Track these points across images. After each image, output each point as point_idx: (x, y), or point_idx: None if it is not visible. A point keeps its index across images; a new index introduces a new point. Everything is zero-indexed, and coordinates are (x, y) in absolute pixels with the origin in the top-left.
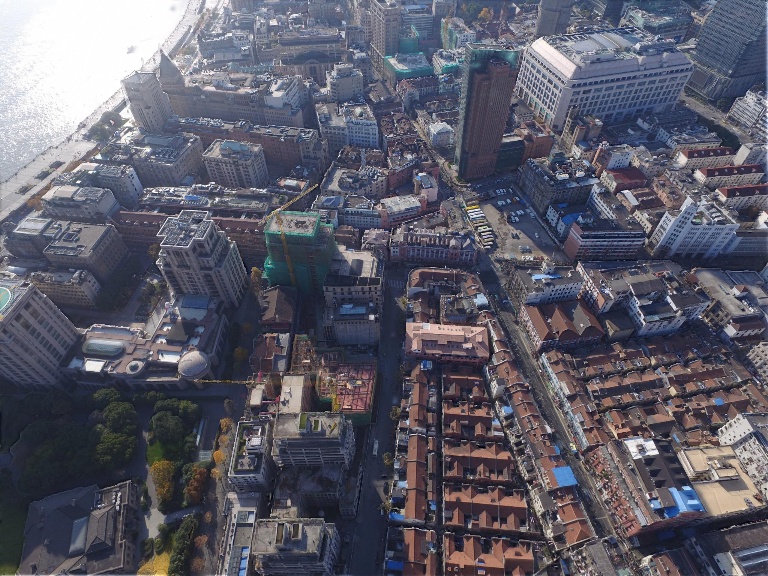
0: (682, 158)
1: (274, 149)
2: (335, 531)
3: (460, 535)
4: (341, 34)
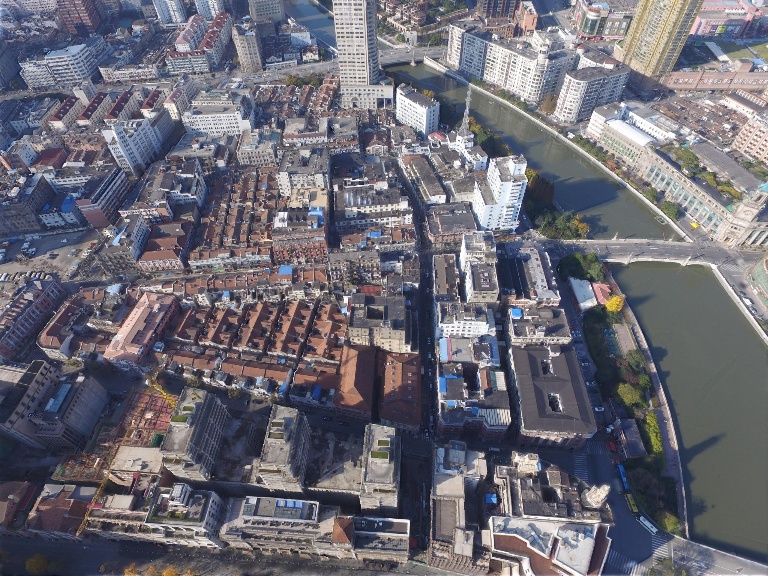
0: (57, 124)
1: None
2: None
3: (306, 349)
4: None
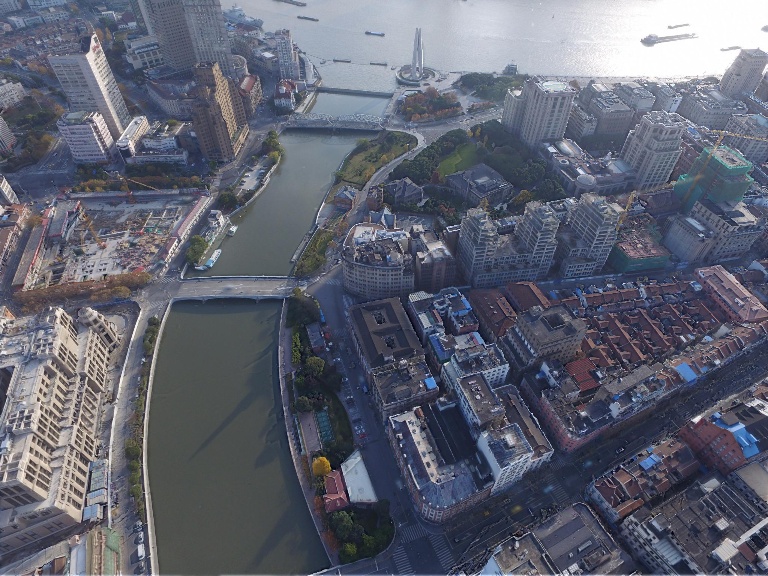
0: None
1: None
2: (553, 253)
3: None
4: None
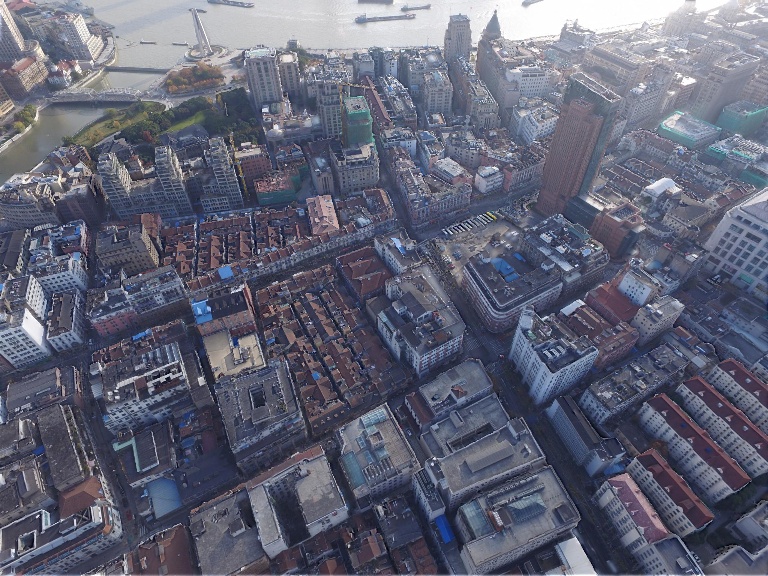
0: None
1: None
2: (183, 190)
3: None
4: (685, 79)
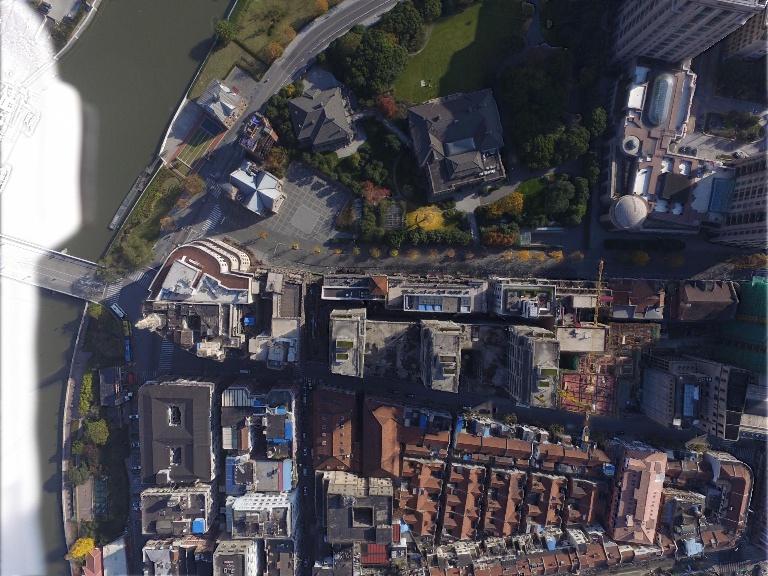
0: None
1: None
2: None
3: (443, 475)
4: None
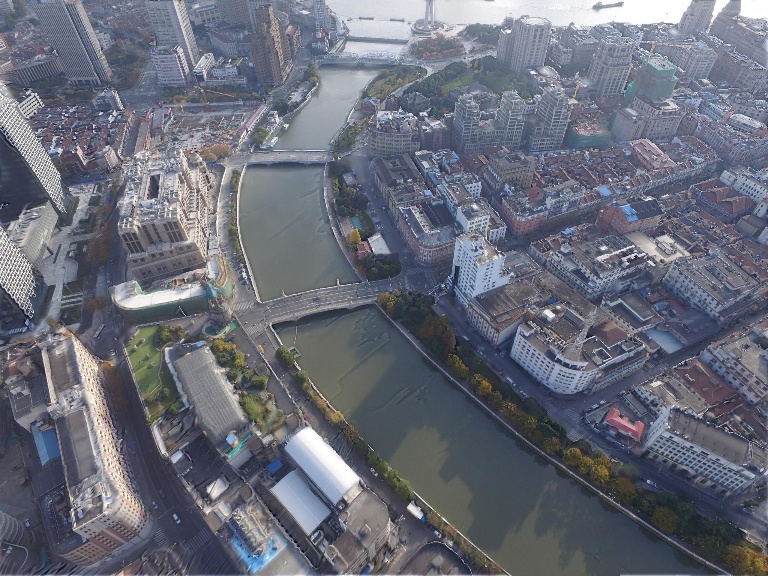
0: None
1: (728, 69)
2: None
3: None
4: None
